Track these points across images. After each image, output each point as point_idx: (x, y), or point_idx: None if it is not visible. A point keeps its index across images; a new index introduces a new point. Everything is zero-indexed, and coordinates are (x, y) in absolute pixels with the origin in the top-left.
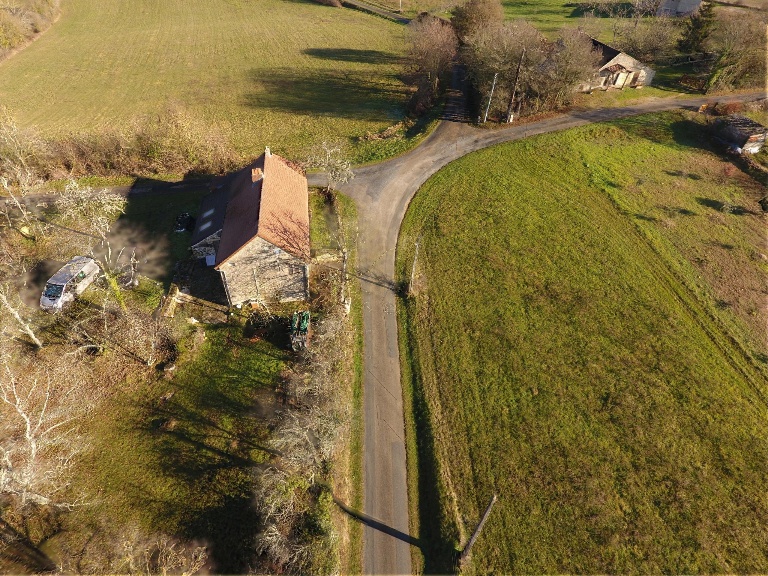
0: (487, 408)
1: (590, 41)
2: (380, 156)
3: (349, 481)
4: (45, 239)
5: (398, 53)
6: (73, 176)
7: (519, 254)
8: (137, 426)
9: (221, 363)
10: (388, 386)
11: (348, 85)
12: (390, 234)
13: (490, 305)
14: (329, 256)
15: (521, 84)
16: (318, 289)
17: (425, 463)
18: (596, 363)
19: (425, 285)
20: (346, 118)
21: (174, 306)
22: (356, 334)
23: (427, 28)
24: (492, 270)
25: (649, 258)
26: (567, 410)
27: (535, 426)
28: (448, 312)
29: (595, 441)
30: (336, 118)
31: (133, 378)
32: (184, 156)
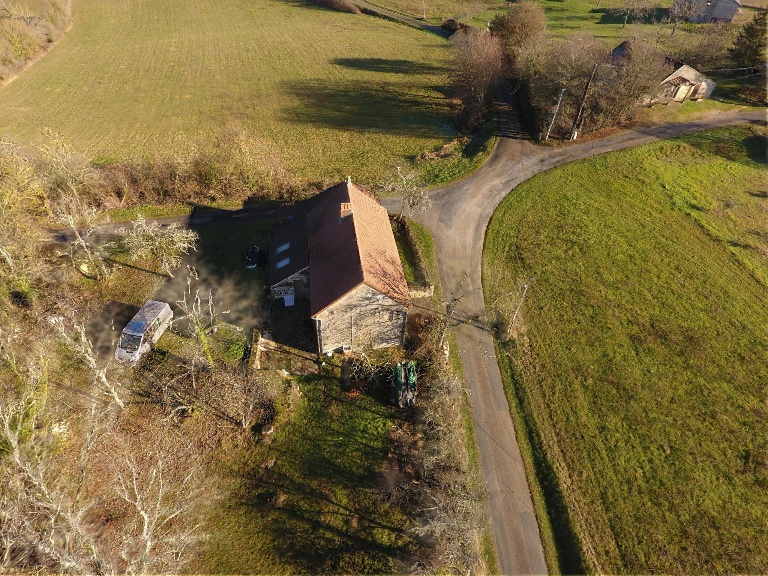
0: (619, 470)
1: (664, 55)
2: (445, 178)
3: (482, 562)
4: (108, 278)
5: (431, 63)
6: (126, 205)
7: (615, 288)
8: (241, 501)
9: (322, 423)
10: (504, 445)
11: (387, 98)
12: (473, 266)
13: (597, 347)
14: (415, 293)
15: (588, 100)
16: (421, 337)
17: (562, 538)
18: (726, 414)
19: (522, 325)
20: (394, 134)
21: (259, 355)
22: (459, 384)
23: (472, 39)
24: (590, 307)
25: (755, 291)
26: (706, 471)
27: (676, 491)
28: (553, 356)
29: (745, 509)
30: (384, 134)
31: (228, 443)
32: (244, 182)
